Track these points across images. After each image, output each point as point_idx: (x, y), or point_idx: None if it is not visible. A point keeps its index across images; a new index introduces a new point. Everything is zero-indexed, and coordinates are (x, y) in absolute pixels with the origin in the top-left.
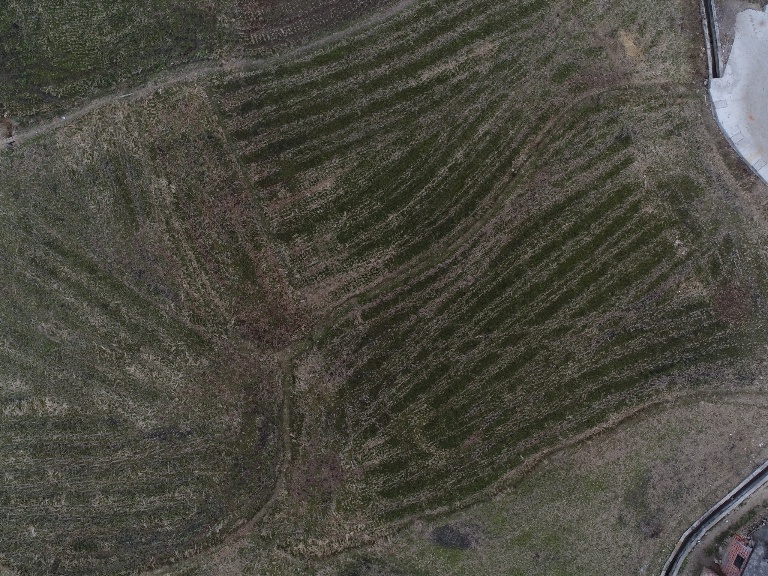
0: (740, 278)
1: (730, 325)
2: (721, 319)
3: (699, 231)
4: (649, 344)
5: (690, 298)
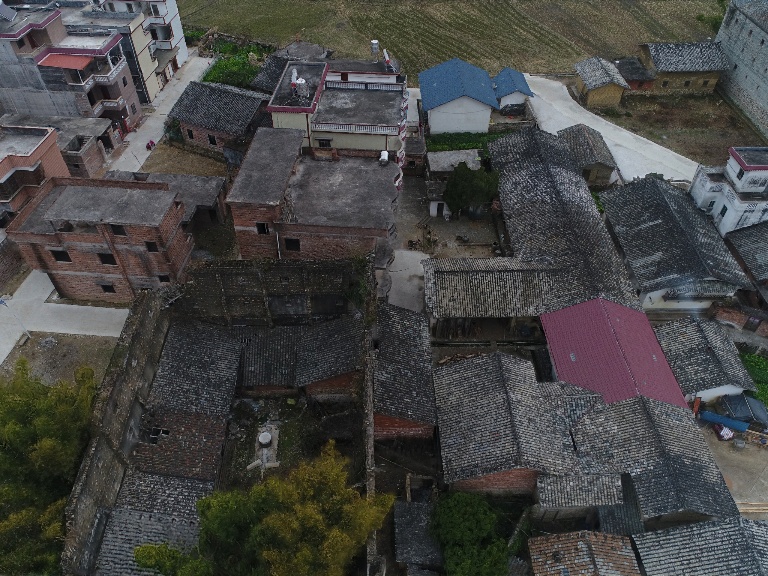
0: None
1: None
2: None
3: None
4: None
5: None
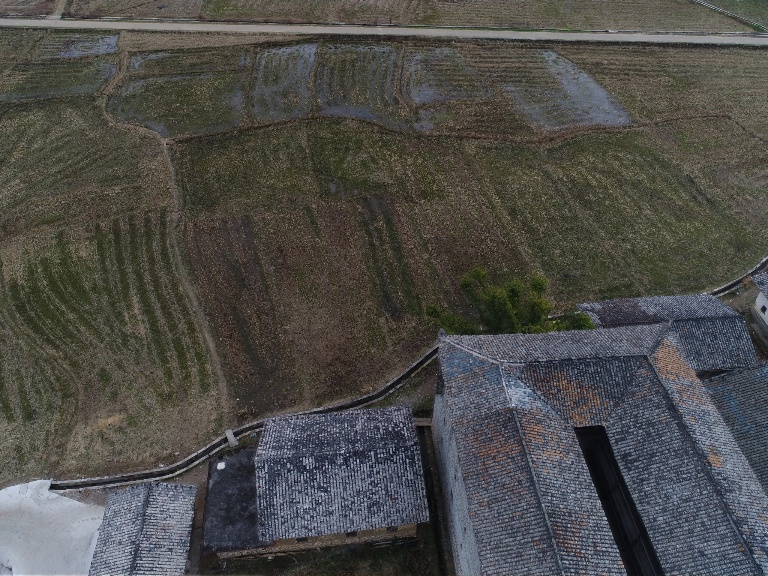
0: None
1: None
2: None
3: None
4: None
5: None
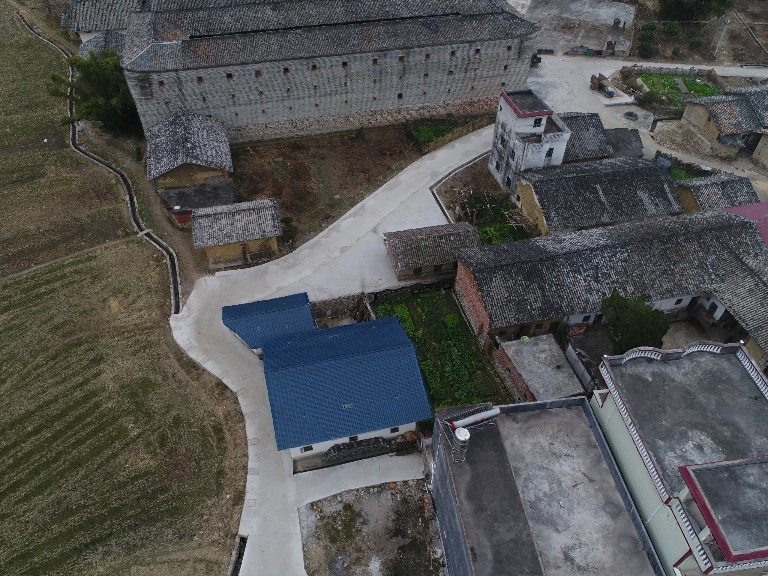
0: (186, 446)
1: (173, 487)
2: (165, 483)
3: (152, 415)
4: (90, 518)
5: (137, 470)
